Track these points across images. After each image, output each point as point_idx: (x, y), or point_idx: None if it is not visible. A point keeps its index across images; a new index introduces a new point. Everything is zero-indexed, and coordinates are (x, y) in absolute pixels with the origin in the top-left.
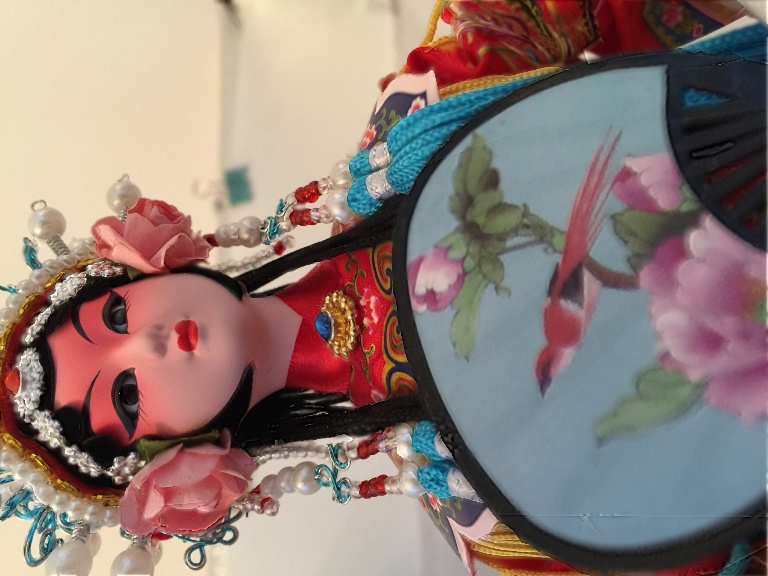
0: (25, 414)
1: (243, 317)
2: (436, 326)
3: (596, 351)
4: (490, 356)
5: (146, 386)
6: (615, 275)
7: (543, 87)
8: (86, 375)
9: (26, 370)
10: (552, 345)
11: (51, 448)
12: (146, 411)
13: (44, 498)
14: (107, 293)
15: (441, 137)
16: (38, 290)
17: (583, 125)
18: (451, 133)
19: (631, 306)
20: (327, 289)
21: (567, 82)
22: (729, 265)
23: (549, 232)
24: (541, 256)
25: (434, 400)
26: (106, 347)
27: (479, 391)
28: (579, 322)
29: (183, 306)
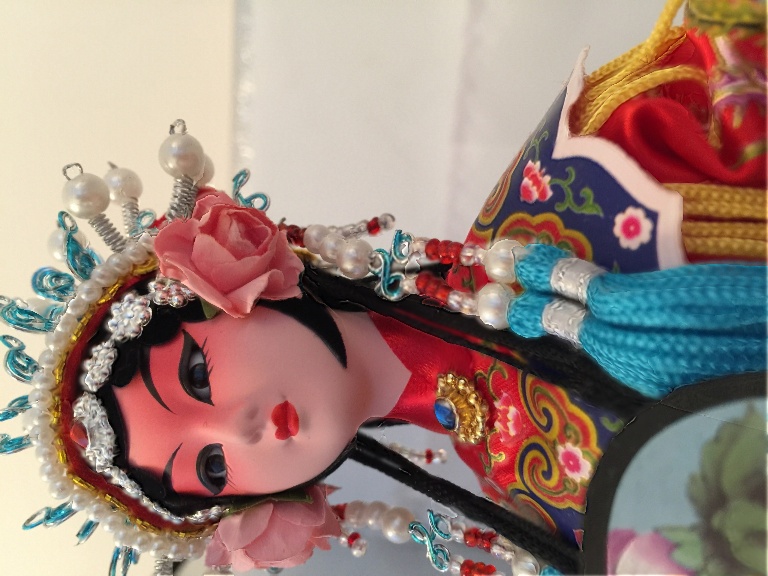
0: (96, 465)
1: (349, 395)
2: None
3: None
4: None
5: (236, 464)
6: None
7: None
8: (166, 446)
9: (93, 425)
10: None
11: None
12: (235, 482)
13: (126, 542)
14: (180, 336)
15: (688, 355)
16: (90, 307)
17: None
18: (705, 356)
19: None
20: (447, 351)
21: None
22: None
23: None
24: None
25: None
26: (187, 419)
27: None
28: None
29: (279, 383)
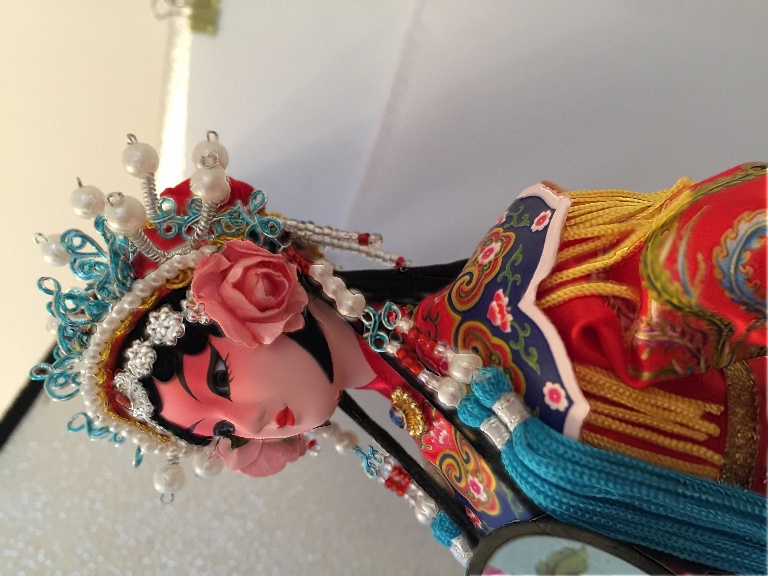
0: (133, 413)
1: (332, 402)
2: None
3: None
4: None
5: (243, 431)
6: None
7: (651, 573)
8: (192, 418)
9: (135, 397)
10: None
11: None
12: None
13: None
14: (207, 348)
15: (560, 501)
16: (130, 309)
17: None
18: (569, 505)
19: None
20: None
21: None
22: None
23: None
24: None
25: None
26: (211, 407)
27: None
28: None
29: (283, 397)
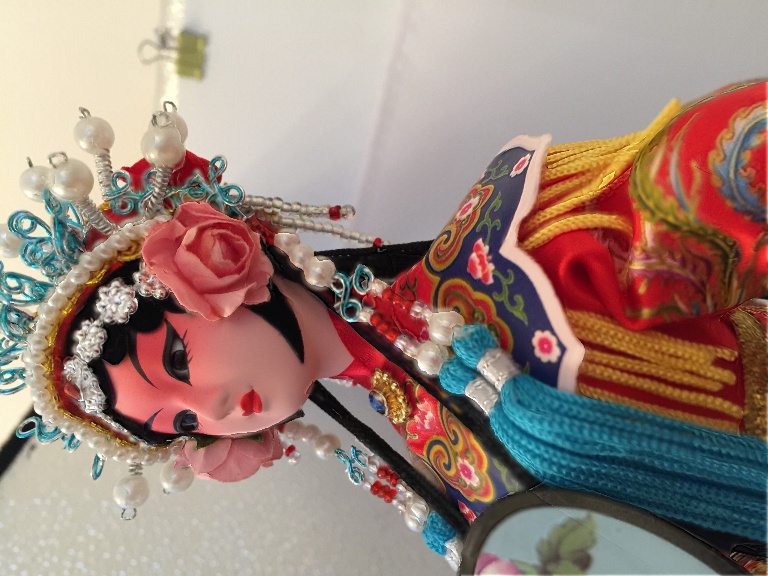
0: (86, 408)
1: (304, 385)
2: None
3: None
4: None
5: (206, 424)
6: None
7: (670, 539)
8: (149, 409)
9: (85, 386)
10: None
11: None
12: (203, 431)
13: (108, 456)
14: (163, 326)
15: (559, 465)
16: (78, 286)
17: None
18: (570, 468)
19: None
20: None
21: (691, 555)
22: None
23: None
24: None
25: None
26: (169, 394)
27: None
28: None
29: (248, 378)
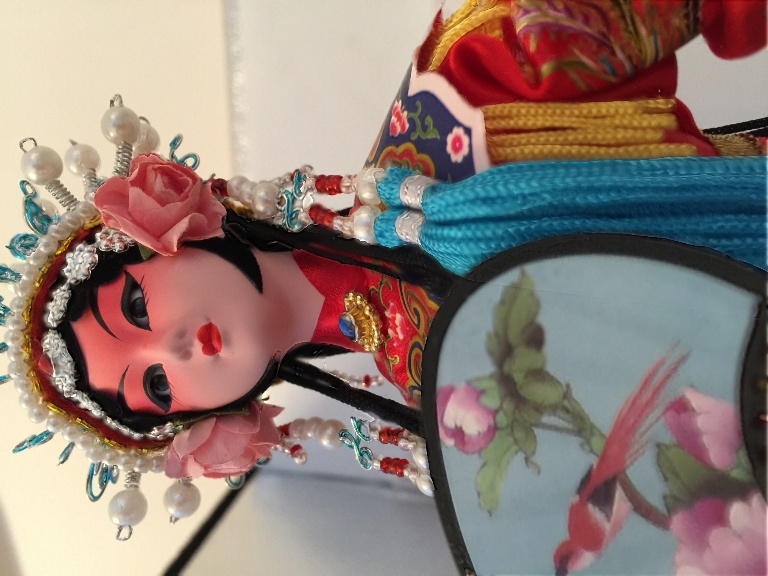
0: (64, 391)
1: (265, 315)
2: (462, 467)
3: (614, 568)
4: (512, 522)
5: (176, 380)
6: (648, 505)
7: (611, 250)
8: (116, 368)
9: (56, 355)
10: (573, 542)
11: (94, 415)
12: (178, 398)
13: (96, 458)
14: (122, 276)
15: (485, 238)
16: (49, 258)
17: (648, 323)
18: (496, 237)
19: (657, 544)
20: (350, 275)
21: (640, 258)
22: (763, 553)
23: (589, 429)
24: (576, 449)
25: (455, 534)
26: (131, 344)
27: (498, 548)
28: (603, 533)
29: (203, 308)
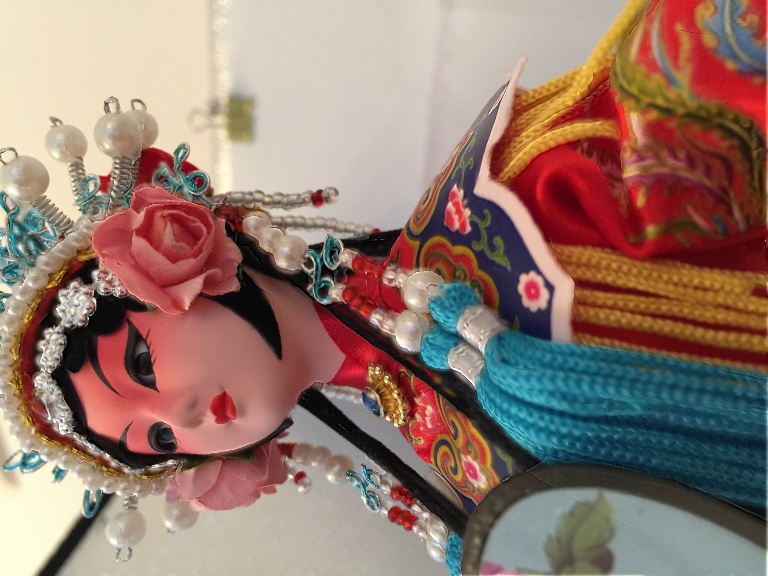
0: (59, 429)
1: (283, 384)
2: None
3: None
4: None
5: (183, 438)
6: None
7: (709, 516)
8: (118, 423)
9: (51, 401)
10: None
11: None
12: (184, 449)
13: (94, 486)
14: (124, 326)
15: (558, 434)
16: (38, 291)
17: None
18: (572, 437)
19: None
20: None
21: (742, 537)
22: None
23: None
24: None
25: None
26: (136, 403)
27: None
28: None
29: (217, 377)
